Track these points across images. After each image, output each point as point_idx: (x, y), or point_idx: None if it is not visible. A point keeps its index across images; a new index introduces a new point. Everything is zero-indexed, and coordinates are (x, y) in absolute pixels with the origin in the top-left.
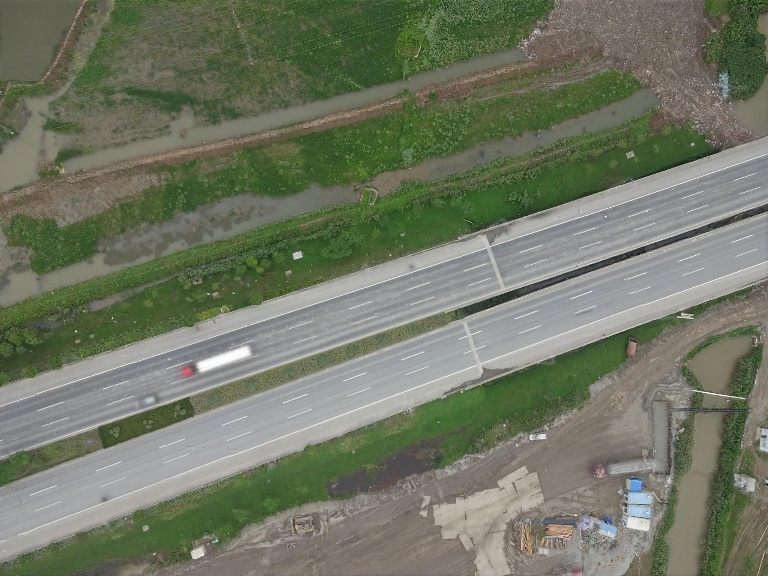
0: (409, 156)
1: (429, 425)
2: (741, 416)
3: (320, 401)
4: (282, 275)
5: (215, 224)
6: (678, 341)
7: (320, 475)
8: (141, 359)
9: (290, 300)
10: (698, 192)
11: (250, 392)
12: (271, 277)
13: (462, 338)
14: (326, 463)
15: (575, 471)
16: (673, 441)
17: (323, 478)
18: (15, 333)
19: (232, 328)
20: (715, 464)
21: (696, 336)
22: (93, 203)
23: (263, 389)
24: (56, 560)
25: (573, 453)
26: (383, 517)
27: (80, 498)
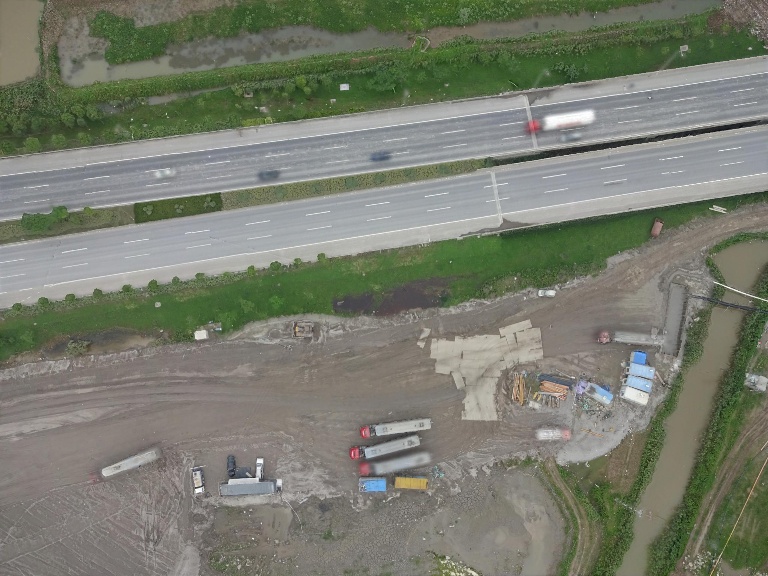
0: (465, 14)
1: (441, 264)
2: (762, 317)
3: (341, 220)
4: (327, 102)
5: (274, 47)
6: (706, 231)
7: (328, 290)
8: (184, 151)
9: (330, 124)
10: (748, 88)
11: (277, 198)
12: (316, 102)
13: (487, 187)
14: (336, 279)
15: (579, 335)
16: (686, 327)
17: (330, 293)
18: (79, 105)
19: (272, 139)
20: (727, 362)
21: (726, 230)
22: (170, 12)
23: (290, 198)
24: (73, 317)
25: (580, 317)
26: (381, 339)
27: (105, 264)
